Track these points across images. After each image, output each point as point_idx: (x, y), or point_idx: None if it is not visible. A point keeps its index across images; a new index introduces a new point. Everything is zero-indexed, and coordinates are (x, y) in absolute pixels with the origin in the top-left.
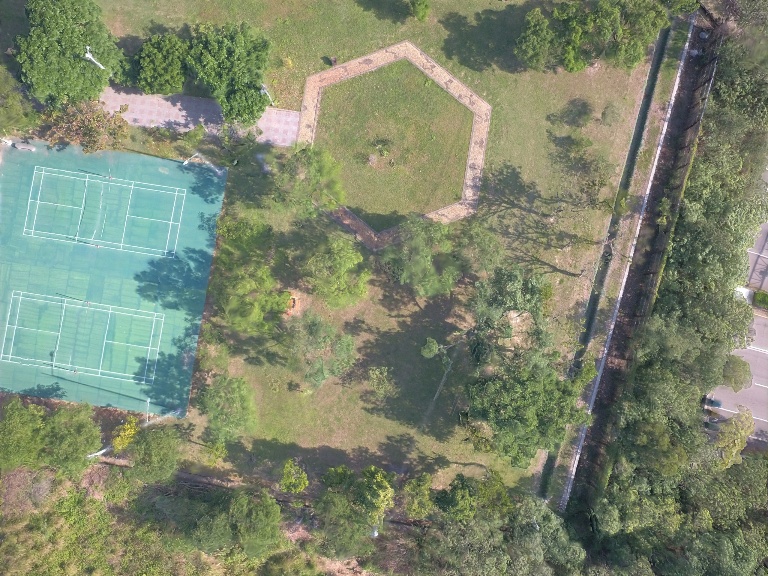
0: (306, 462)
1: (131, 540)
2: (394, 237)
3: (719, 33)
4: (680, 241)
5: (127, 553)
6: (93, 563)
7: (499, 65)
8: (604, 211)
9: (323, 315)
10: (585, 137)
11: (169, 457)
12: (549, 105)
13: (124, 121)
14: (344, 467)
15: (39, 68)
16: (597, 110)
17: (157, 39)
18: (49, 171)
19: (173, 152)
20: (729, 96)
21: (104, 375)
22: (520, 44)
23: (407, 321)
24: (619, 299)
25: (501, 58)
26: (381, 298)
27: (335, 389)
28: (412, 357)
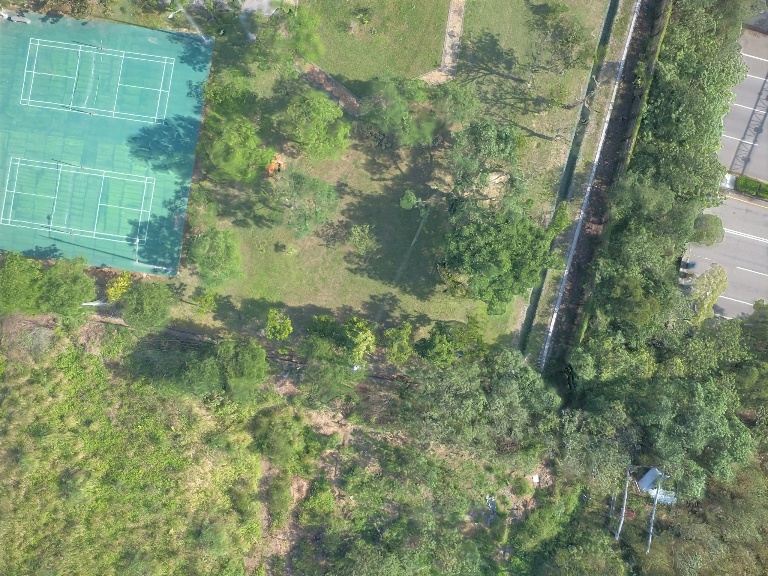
0: (292, 320)
1: (126, 394)
2: (375, 103)
3: None
4: (654, 102)
5: (123, 406)
6: (91, 416)
7: None
8: (578, 68)
9: (307, 179)
10: (562, 5)
11: (160, 306)
12: None
13: None
14: (327, 317)
15: None
16: None
17: None
18: (44, 43)
19: (162, 23)
20: None
21: (99, 237)
22: None
23: (389, 184)
24: (595, 162)
25: None
26: (363, 162)
27: (320, 250)
28: (394, 219)
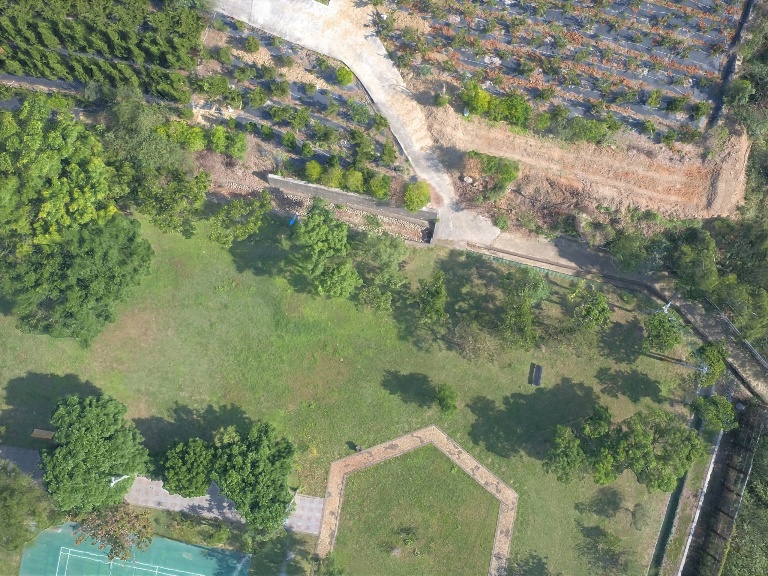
0: None
1: None
2: None
3: (757, 420)
4: None
5: None
6: None
7: (527, 451)
8: None
9: None
10: (614, 527)
11: None
12: (578, 493)
13: (149, 522)
14: None
15: (65, 488)
16: (627, 498)
17: (182, 448)
18: (75, 553)
19: (197, 537)
20: (765, 492)
21: None
22: (550, 461)
23: None
24: None
25: (529, 444)
26: None
27: None
28: None
